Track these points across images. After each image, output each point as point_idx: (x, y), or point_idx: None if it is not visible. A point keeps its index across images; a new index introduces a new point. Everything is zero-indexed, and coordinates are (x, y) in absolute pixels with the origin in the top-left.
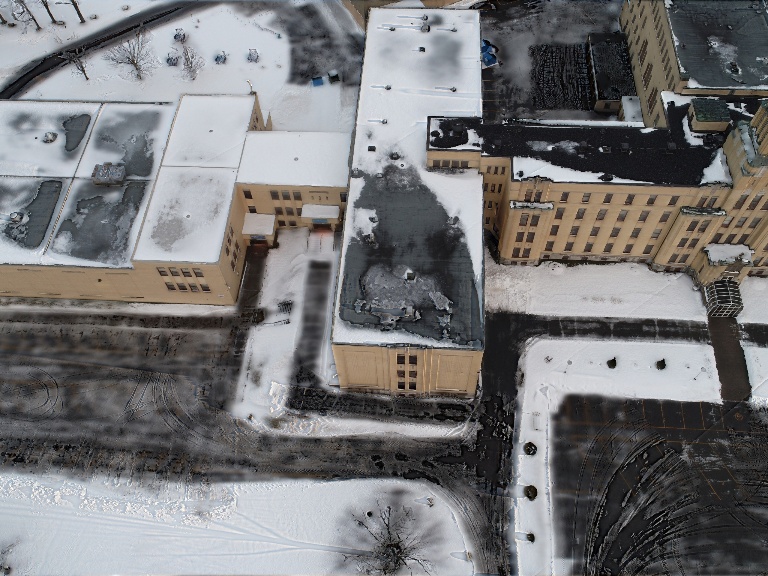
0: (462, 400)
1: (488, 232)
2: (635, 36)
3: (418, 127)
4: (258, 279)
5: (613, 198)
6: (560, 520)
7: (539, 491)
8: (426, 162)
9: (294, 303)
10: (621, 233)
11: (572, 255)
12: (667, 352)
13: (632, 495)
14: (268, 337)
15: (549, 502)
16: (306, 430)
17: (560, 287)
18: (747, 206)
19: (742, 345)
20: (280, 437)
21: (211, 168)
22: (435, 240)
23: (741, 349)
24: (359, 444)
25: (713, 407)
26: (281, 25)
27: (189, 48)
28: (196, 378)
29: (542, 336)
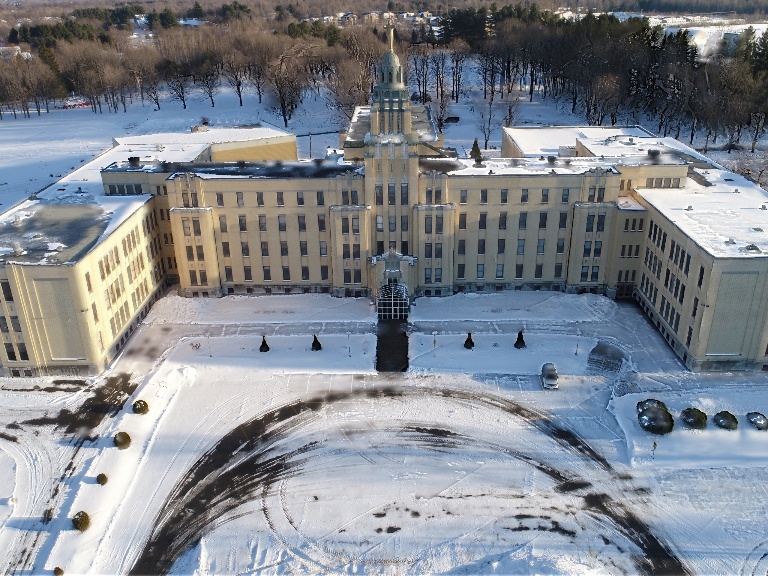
0: (84, 377)
1: None
2: None
3: None
4: None
5: (264, 198)
6: (150, 469)
7: (135, 443)
8: None
9: None
10: (290, 249)
11: (255, 286)
12: (327, 340)
13: (248, 445)
14: None
15: (143, 453)
16: None
17: (235, 307)
18: (387, 199)
19: (408, 334)
20: None
21: None
22: (80, 222)
23: (406, 337)
24: None
25: (366, 377)
26: None
27: None
28: None
29: None
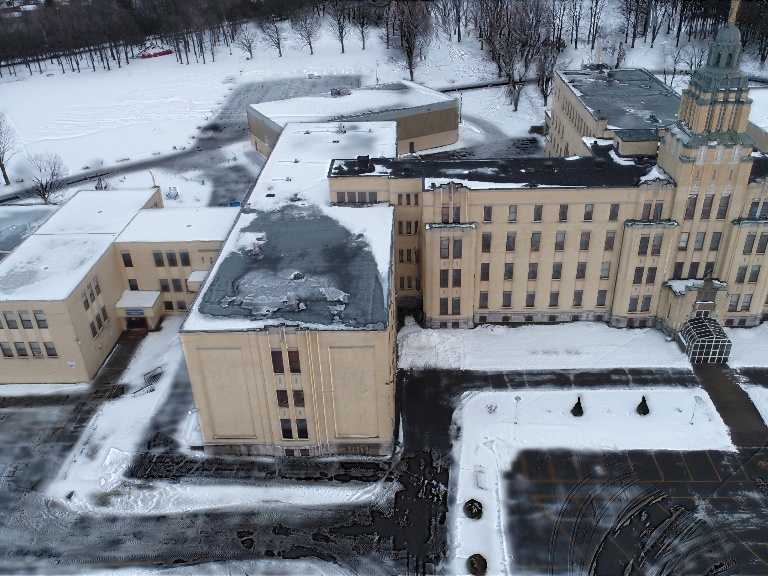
0: (375, 457)
1: (412, 300)
2: (557, 153)
3: (324, 181)
4: (127, 358)
5: (543, 212)
6: None
7: (490, 566)
8: (330, 201)
9: (165, 372)
10: (564, 271)
11: (513, 314)
12: (648, 398)
13: (634, 568)
14: (122, 409)
15: None
16: (146, 505)
17: (502, 344)
18: (700, 213)
19: (743, 388)
20: (106, 517)
21: (89, 234)
22: (333, 250)
23: (743, 392)
24: (221, 518)
25: (725, 455)
26: (207, 177)
27: (104, 180)
28: (9, 457)
29: (482, 389)
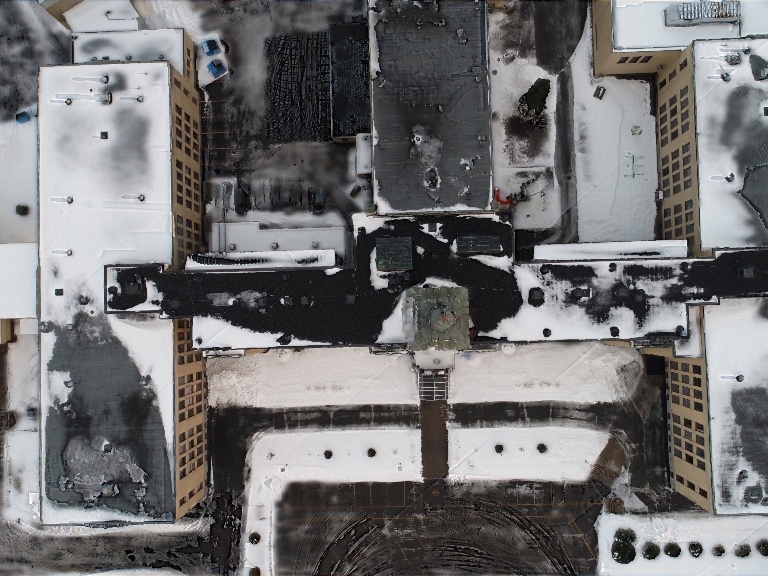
0: None
1: None
2: None
3: (105, 259)
4: (3, 379)
5: None
6: None
7: (263, 570)
8: None
9: (38, 410)
10: None
11: None
12: (379, 439)
13: (339, 566)
14: (21, 443)
15: None
16: (67, 531)
17: (286, 376)
18: None
19: (447, 427)
20: (47, 537)
21: None
22: (129, 405)
23: (446, 431)
24: (113, 540)
25: (415, 486)
26: None
27: None
28: None
29: (267, 430)
